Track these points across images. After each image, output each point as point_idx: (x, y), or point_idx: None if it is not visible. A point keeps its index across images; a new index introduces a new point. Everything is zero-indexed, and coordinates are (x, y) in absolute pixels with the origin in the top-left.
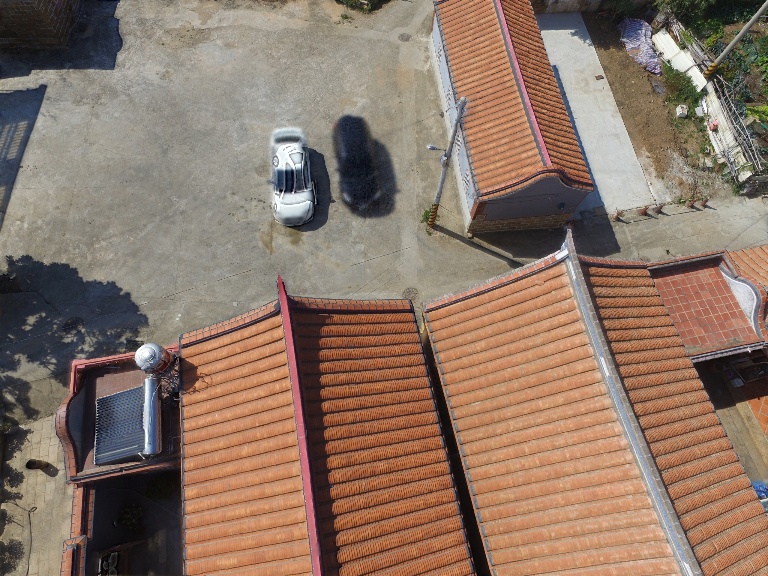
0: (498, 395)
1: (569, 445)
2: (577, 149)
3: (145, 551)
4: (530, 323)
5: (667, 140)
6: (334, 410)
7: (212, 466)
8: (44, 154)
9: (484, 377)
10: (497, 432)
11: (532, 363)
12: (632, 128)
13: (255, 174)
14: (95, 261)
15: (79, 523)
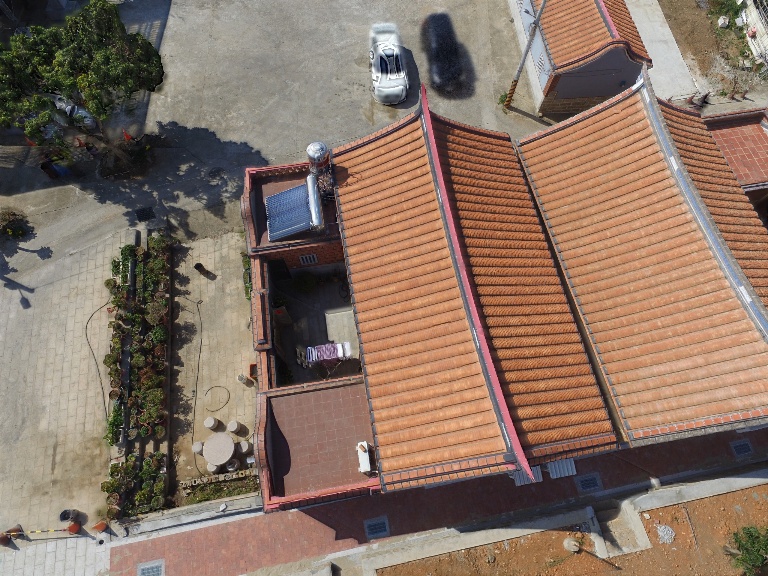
0: (583, 199)
1: (644, 226)
2: (637, 34)
3: (292, 332)
4: (609, 143)
5: (710, 45)
6: (462, 191)
7: (367, 232)
8: (177, 46)
9: (571, 187)
10: (583, 224)
11: (611, 172)
12: (678, 36)
13: (355, 64)
14: (229, 127)
15: (260, 282)
